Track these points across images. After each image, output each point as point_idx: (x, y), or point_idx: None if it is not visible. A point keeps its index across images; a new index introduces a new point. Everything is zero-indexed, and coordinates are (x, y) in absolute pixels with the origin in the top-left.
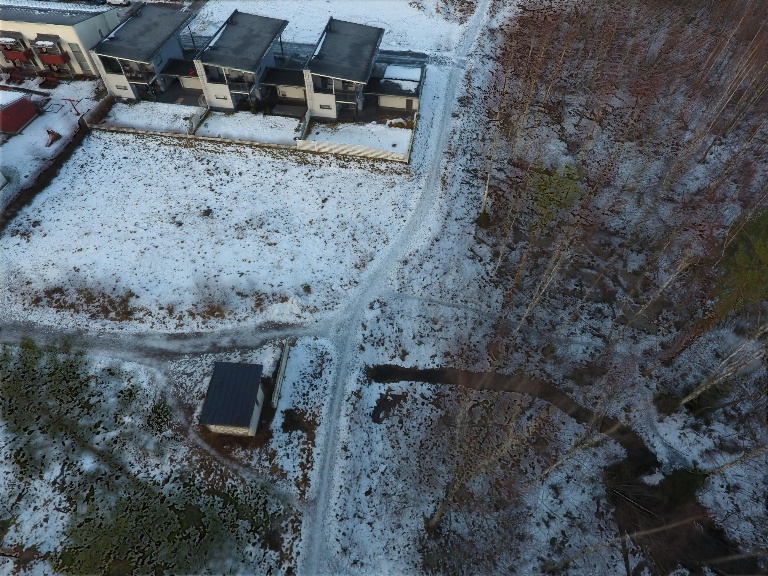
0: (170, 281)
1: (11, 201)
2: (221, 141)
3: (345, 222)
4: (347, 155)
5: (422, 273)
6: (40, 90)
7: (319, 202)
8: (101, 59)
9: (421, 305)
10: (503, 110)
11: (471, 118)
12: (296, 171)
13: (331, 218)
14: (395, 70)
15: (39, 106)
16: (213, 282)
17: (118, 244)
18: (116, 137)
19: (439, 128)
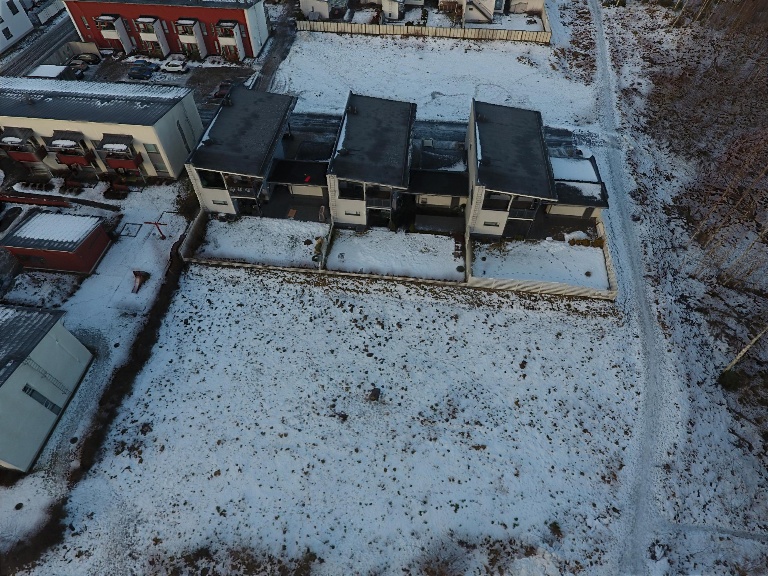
0: (360, 527)
1: (104, 390)
2: (364, 277)
3: (562, 400)
4: (534, 292)
5: (694, 484)
6: (106, 202)
7: (517, 368)
8: (198, 172)
9: (711, 541)
10: (678, 202)
11: (653, 219)
12: (470, 317)
13: (542, 395)
14: (559, 165)
15: (110, 227)
16: (421, 525)
17: (268, 459)
18: (222, 273)
19: (624, 239)
